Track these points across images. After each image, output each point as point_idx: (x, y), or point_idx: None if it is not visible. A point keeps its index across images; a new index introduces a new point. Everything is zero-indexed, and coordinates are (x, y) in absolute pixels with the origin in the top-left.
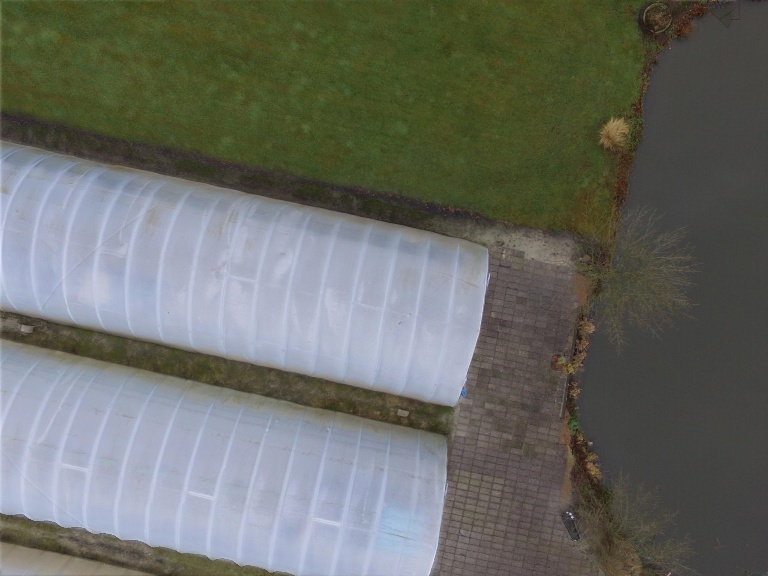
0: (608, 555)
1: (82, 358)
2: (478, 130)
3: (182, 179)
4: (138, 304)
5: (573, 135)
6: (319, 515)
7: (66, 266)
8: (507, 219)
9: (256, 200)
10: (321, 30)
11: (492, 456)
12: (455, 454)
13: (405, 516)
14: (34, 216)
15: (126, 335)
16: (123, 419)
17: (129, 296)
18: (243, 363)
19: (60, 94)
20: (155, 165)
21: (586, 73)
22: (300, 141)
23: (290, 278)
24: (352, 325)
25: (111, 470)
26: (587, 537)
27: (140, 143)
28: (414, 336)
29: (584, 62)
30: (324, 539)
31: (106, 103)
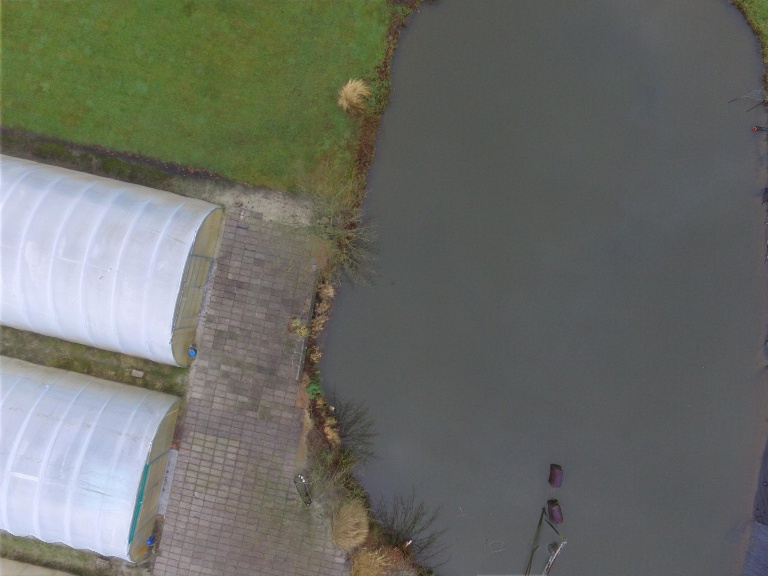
0: (335, 519)
1: None
2: (218, 90)
3: None
4: None
5: (314, 97)
6: (18, 470)
7: None
8: (246, 180)
9: None
10: None
11: (227, 418)
12: (190, 416)
13: (104, 472)
14: None
15: None
16: None
17: None
18: None
19: None
20: None
21: (328, 34)
22: (39, 99)
23: None
24: (53, 279)
25: None
26: (322, 502)
27: None
28: (115, 291)
29: (326, 23)
30: (22, 494)
31: None
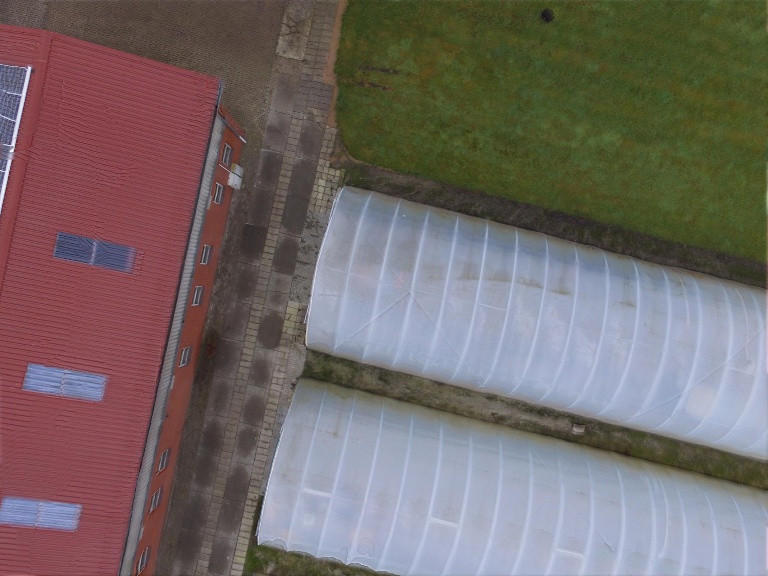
0: None
1: (635, 459)
2: None
3: (738, 282)
4: (752, 418)
5: None
6: None
7: (692, 380)
8: None
9: None
10: None
11: None
12: None
13: None
14: (663, 330)
15: (680, 437)
16: (728, 532)
17: (748, 411)
18: None
19: (618, 193)
20: (708, 267)
21: None
22: None
23: None
24: None
25: None
26: None
27: (694, 244)
28: None
29: None
30: None
31: (663, 203)
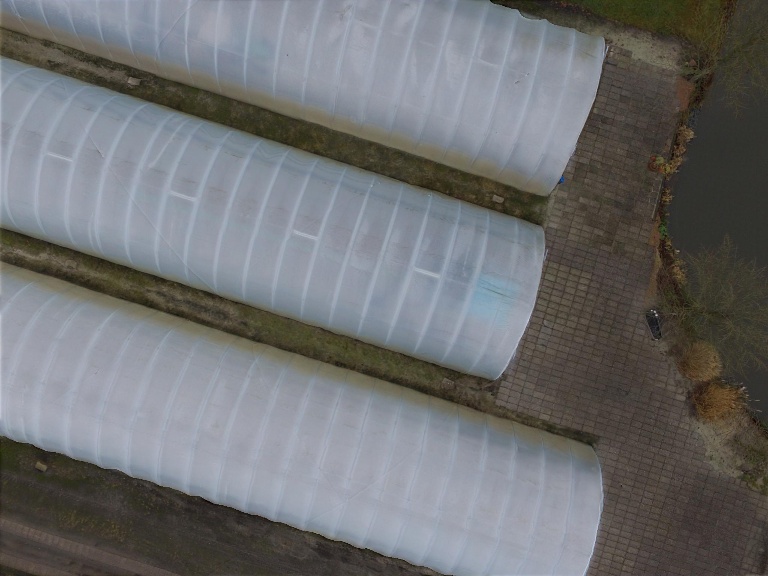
0: (690, 352)
1: (186, 114)
2: None
3: None
4: (258, 43)
5: None
6: (420, 265)
7: None
8: (618, 18)
9: None
10: None
11: (582, 250)
12: None
13: (504, 274)
14: None
15: (232, 95)
16: (232, 157)
17: (251, 32)
18: (345, 134)
19: None
20: None
21: None
22: None
23: (413, 27)
24: (470, 80)
25: (219, 200)
26: (668, 339)
27: None
28: (530, 96)
29: None
30: (423, 289)
31: None
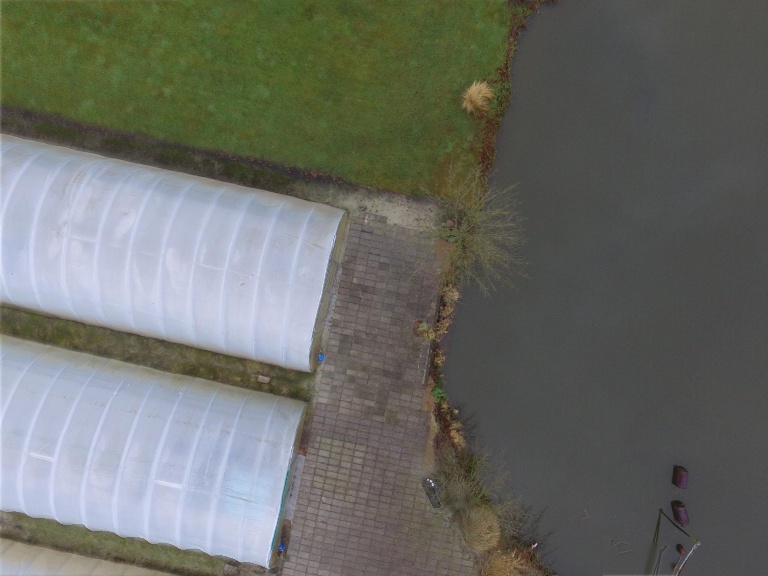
0: (466, 522)
1: None
2: (340, 94)
3: (41, 143)
4: None
5: (437, 99)
6: (161, 477)
7: None
8: (370, 184)
9: (110, 163)
10: None
11: (354, 423)
12: (316, 421)
13: (248, 479)
14: None
15: None
16: None
17: None
18: (102, 328)
19: None
20: (15, 129)
21: (450, 36)
22: (161, 105)
23: (131, 238)
24: (194, 286)
25: None
26: (450, 505)
27: None
28: (256, 297)
29: (448, 25)
30: (166, 502)
31: None
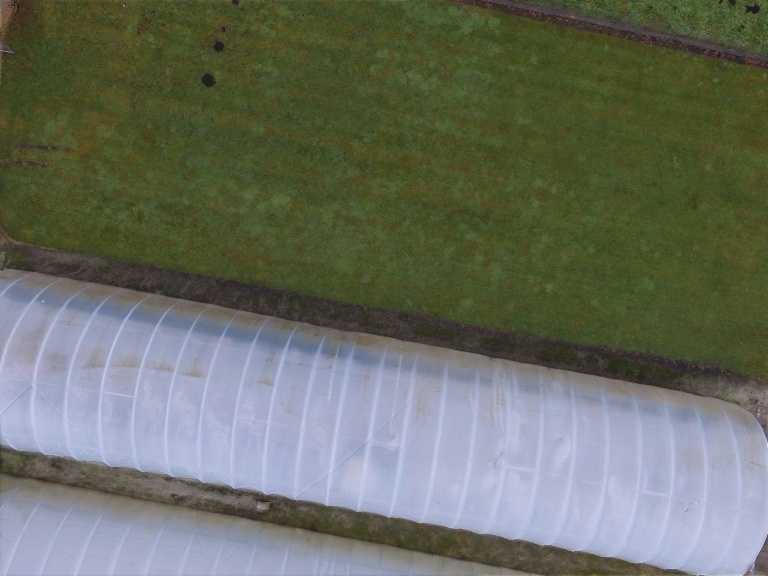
0: None
1: (323, 535)
2: (727, 284)
3: (421, 344)
4: (407, 495)
5: None
6: None
7: (334, 460)
8: (760, 375)
9: (510, 371)
10: (561, 185)
11: None
12: None
13: None
14: (300, 409)
15: None
16: None
17: (399, 488)
18: (491, 535)
19: (291, 259)
20: (391, 329)
21: None
22: (542, 300)
23: (571, 467)
24: (637, 514)
25: None
26: None
27: (375, 307)
28: (703, 524)
29: None
30: None
31: (339, 267)
